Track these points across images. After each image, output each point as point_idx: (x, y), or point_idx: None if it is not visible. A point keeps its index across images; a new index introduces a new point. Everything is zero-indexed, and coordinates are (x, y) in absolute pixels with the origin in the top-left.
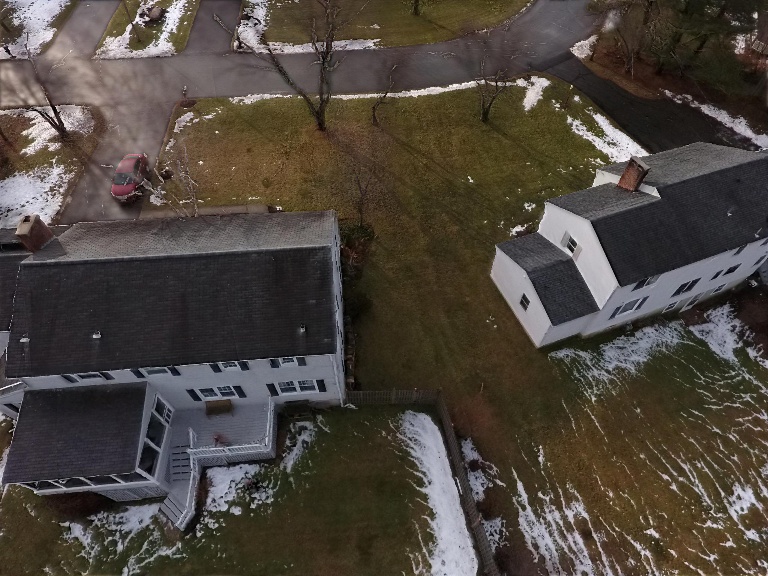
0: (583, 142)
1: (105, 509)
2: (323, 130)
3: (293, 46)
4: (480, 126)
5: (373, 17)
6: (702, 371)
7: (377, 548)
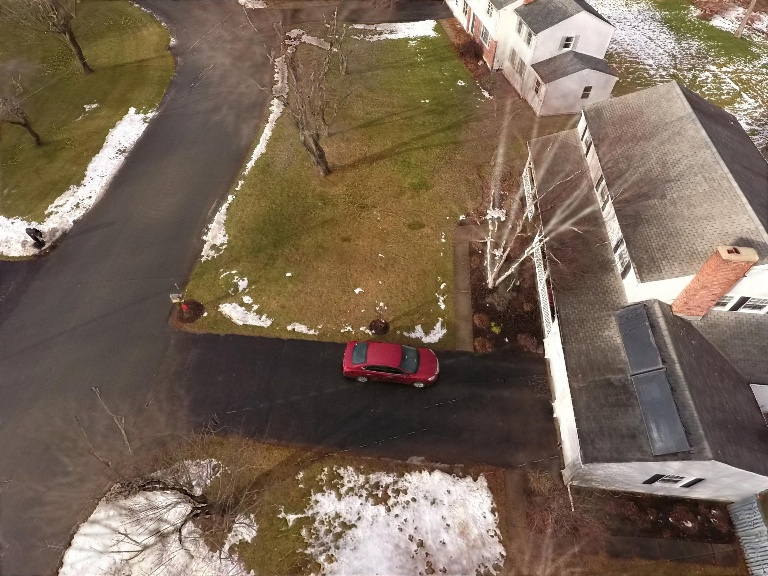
0: (387, 42)
1: None
2: (330, 171)
3: (83, 186)
4: (353, 78)
5: (61, 104)
6: None
7: None
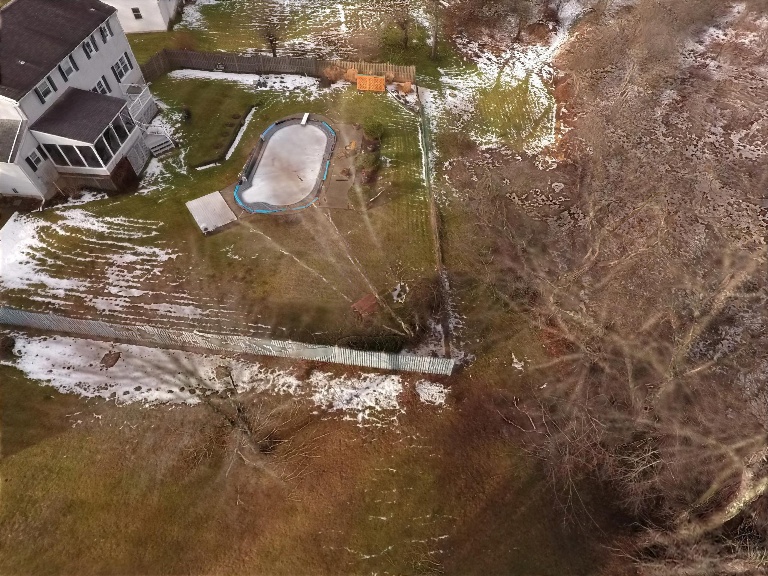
0: None
1: (139, 181)
2: None
3: None
4: None
5: None
6: (217, 8)
7: (228, 93)
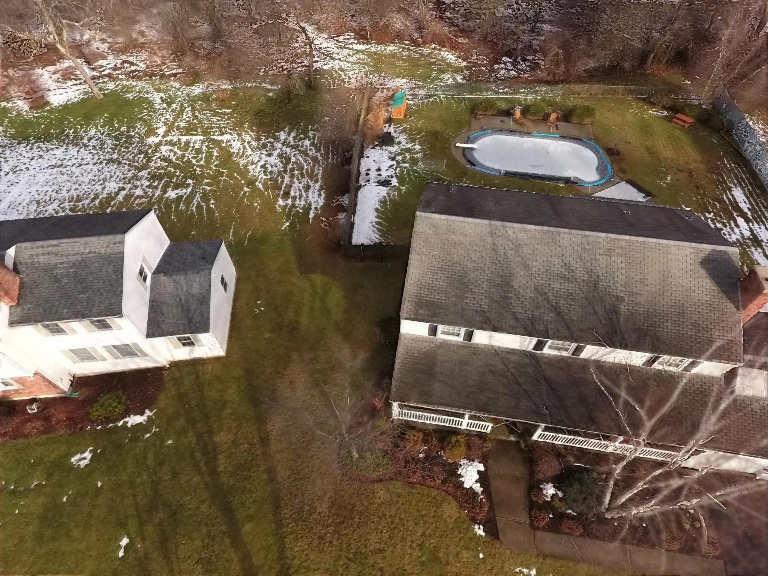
0: None
1: None
2: None
3: None
4: None
5: None
6: None
7: (416, 201)
